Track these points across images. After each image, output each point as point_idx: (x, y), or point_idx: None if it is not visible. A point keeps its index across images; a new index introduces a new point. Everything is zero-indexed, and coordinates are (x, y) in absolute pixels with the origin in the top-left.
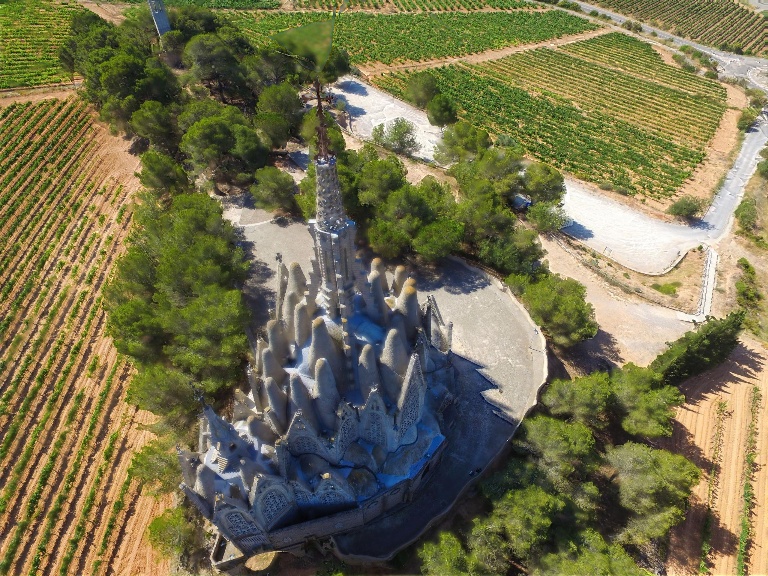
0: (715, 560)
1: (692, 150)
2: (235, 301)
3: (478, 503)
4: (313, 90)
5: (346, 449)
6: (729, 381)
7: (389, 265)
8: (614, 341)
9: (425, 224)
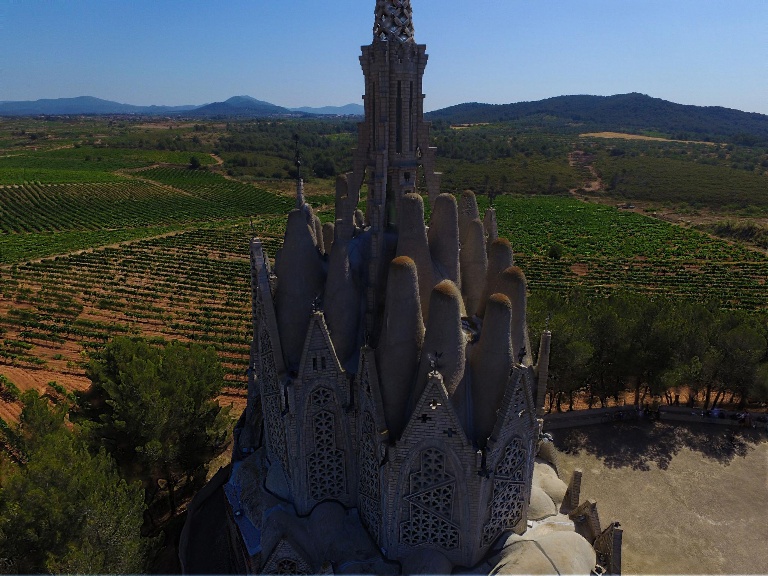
0: None
1: None
2: (552, 327)
3: None
4: None
5: None
6: None
7: None
8: None
9: None
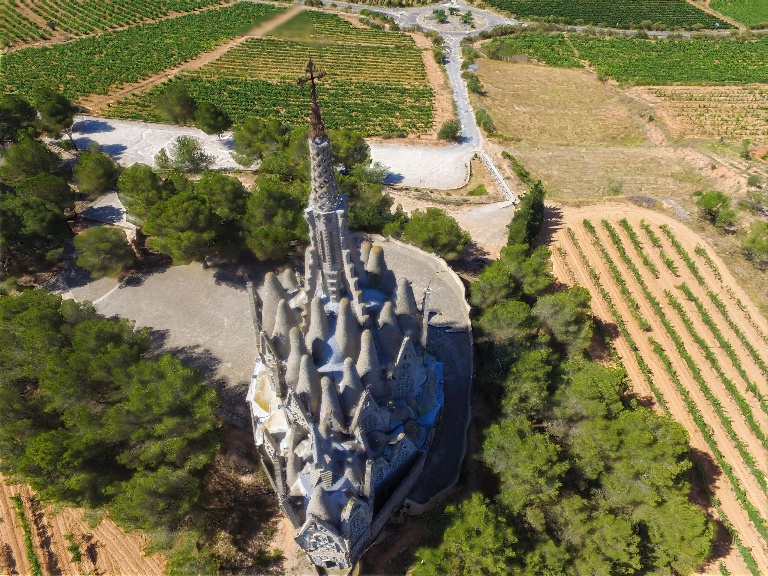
0: (614, 345)
1: (421, 89)
2: (178, 363)
3: (480, 401)
4: (307, 71)
5: (390, 413)
6: (552, 233)
7: (277, 268)
8: (474, 243)
9: (296, 214)
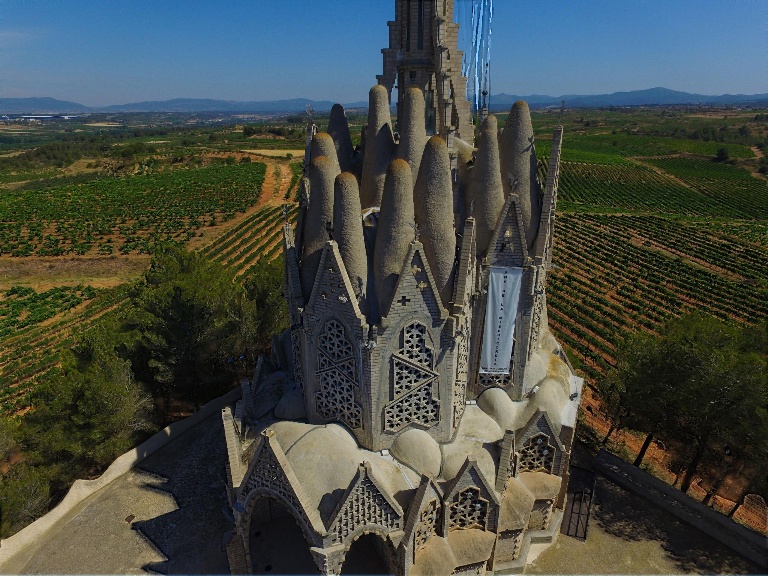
0: None
1: None
2: None
3: None
4: None
5: None
6: None
7: None
8: None
9: None
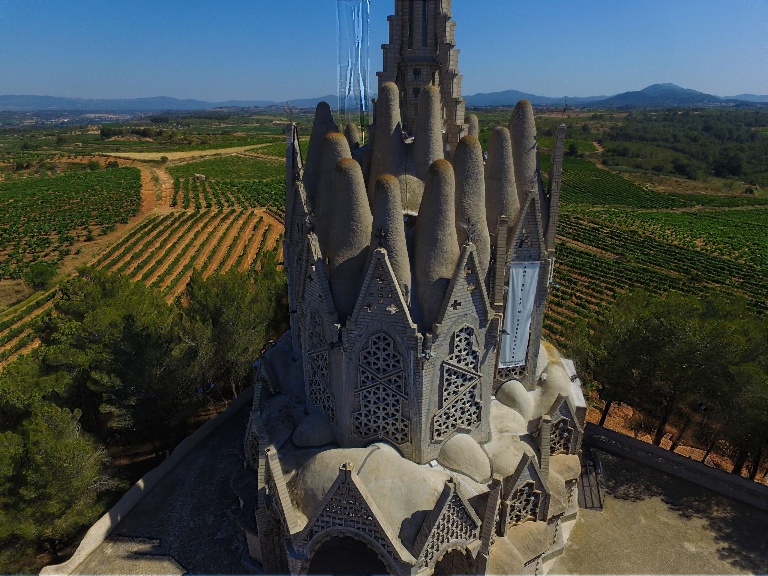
0: None
1: None
2: None
3: None
4: None
5: None
6: None
7: None
8: None
9: None
